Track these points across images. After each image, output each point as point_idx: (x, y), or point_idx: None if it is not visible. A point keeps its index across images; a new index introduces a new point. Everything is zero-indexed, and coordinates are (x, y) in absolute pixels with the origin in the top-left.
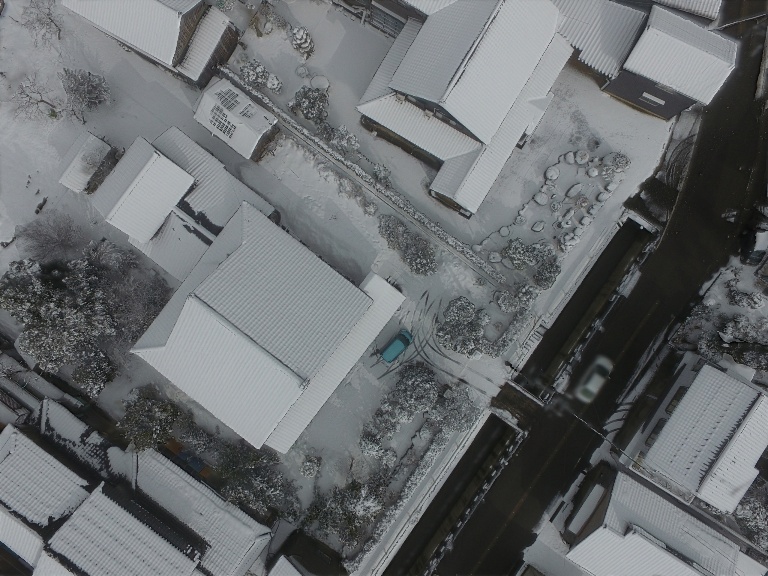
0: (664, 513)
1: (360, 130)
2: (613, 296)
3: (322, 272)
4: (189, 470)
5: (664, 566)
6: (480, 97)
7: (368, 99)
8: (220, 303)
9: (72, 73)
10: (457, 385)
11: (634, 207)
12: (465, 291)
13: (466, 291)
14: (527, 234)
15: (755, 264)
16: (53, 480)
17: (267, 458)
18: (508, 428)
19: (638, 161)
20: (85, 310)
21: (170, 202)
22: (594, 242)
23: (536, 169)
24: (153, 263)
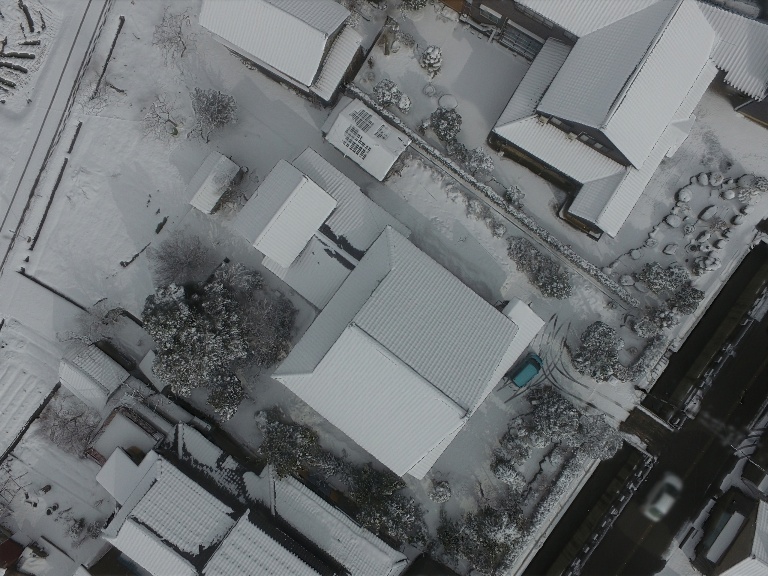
0: None
1: (486, 150)
2: (745, 320)
3: (469, 298)
4: (321, 495)
5: None
6: (637, 122)
7: (507, 121)
8: (379, 332)
9: (204, 93)
10: (585, 409)
11: (767, 230)
12: (595, 314)
13: (596, 314)
14: (658, 257)
15: None
16: (200, 508)
17: None
18: (633, 452)
19: None
20: (223, 334)
21: (313, 226)
22: (725, 265)
23: (667, 190)
24: (278, 284)
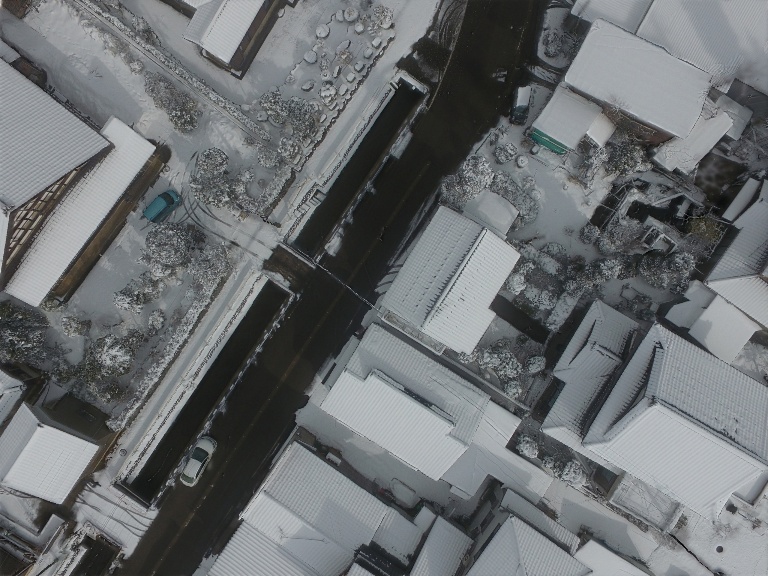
0: (413, 362)
1: None
2: (384, 157)
3: (54, 112)
4: None
5: (404, 409)
6: None
7: None
8: None
9: None
10: (229, 248)
11: (407, 67)
12: (234, 151)
13: (235, 151)
14: (297, 94)
15: (522, 122)
16: None
17: (31, 319)
18: (287, 295)
19: (411, 20)
20: None
21: None
22: (367, 103)
23: (309, 28)
24: None
